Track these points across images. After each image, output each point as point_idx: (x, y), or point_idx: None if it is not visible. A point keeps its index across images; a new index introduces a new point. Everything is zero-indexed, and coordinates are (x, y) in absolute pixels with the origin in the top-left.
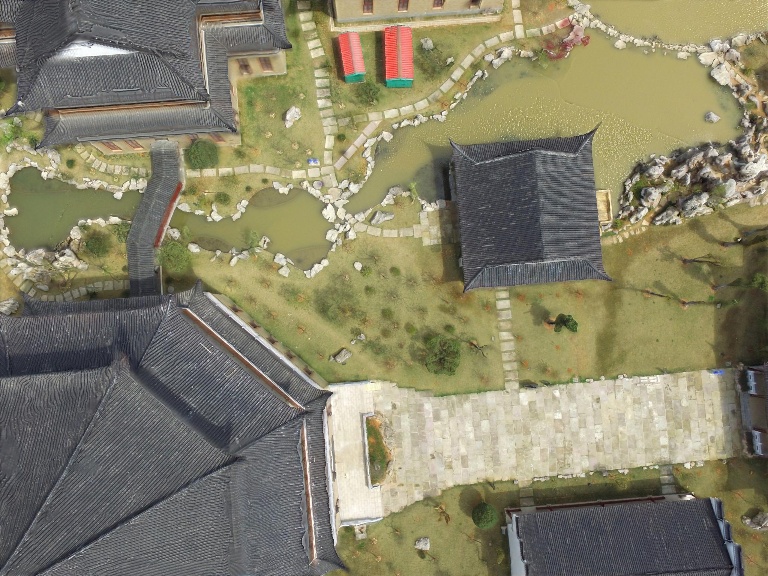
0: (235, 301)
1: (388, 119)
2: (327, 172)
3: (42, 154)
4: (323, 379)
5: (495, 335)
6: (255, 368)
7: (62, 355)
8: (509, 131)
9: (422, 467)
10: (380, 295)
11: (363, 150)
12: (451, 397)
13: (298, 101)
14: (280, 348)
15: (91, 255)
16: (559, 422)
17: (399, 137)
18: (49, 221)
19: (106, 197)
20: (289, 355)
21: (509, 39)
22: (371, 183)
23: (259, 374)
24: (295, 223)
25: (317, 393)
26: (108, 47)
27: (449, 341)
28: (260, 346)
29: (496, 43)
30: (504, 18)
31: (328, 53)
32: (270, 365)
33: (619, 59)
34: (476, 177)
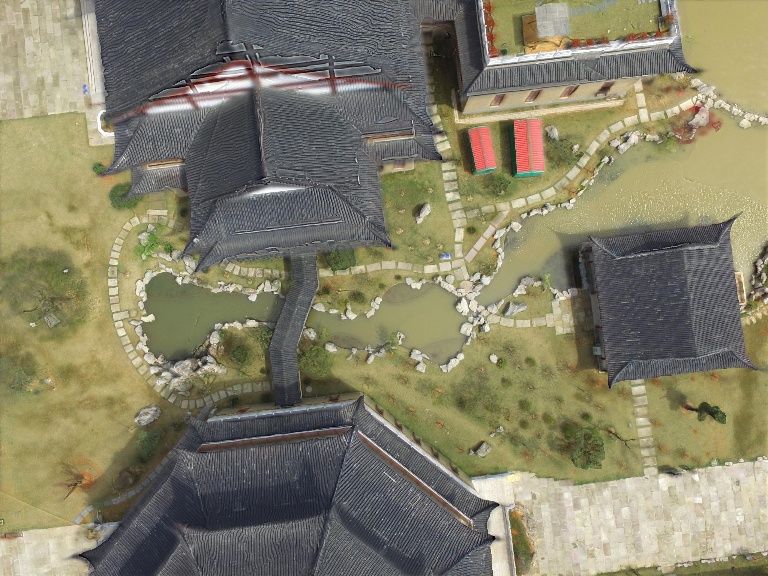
0: (373, 398)
1: (515, 209)
2: (458, 265)
3: (177, 260)
4: (464, 473)
5: (632, 422)
6: (423, 484)
7: (252, 492)
8: (637, 215)
9: (565, 556)
10: (516, 386)
11: (492, 241)
12: (591, 485)
13: (427, 196)
14: (427, 449)
15: (229, 358)
16: (700, 506)
17: (527, 226)
18: (185, 325)
19: (240, 299)
20: (435, 454)
21: (633, 123)
22: (501, 274)
23: (430, 491)
24: (428, 317)
25: (482, 504)
26: (284, 184)
27: (594, 435)
28: (423, 459)
29: (620, 128)
30: (627, 102)
31: (454, 146)
32: (435, 478)
33: (744, 138)
34: (617, 271)
